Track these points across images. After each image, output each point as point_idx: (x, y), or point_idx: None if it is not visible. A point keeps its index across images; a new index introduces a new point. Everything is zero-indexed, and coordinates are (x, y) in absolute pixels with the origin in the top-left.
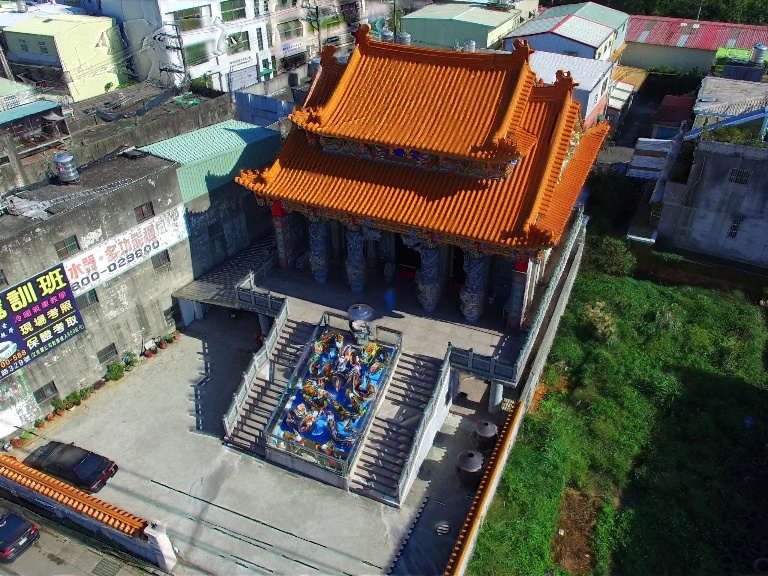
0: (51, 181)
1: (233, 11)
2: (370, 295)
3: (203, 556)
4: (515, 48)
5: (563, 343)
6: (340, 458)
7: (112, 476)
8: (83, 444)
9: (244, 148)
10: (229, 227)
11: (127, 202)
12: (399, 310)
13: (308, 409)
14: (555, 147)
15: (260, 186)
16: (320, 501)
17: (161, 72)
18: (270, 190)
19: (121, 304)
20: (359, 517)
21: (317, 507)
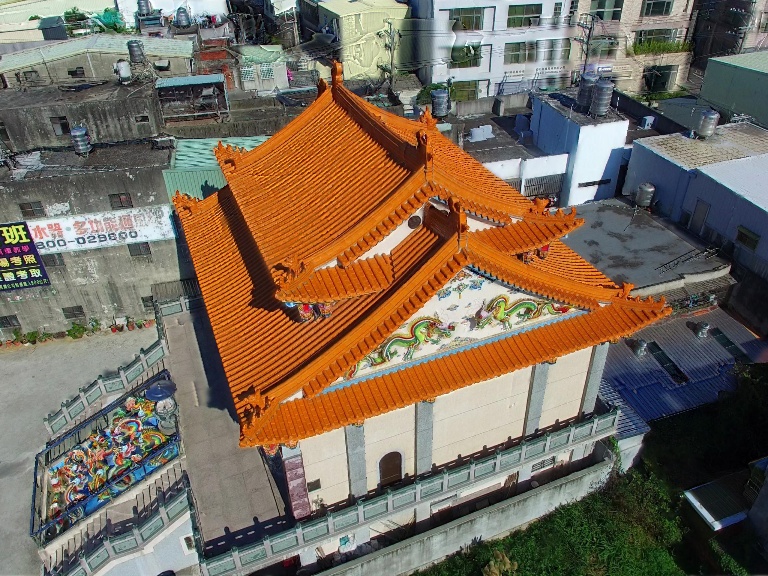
0: None
1: (524, 17)
2: None
3: None
4: None
5: None
6: (63, 526)
7: None
8: None
9: None
10: None
11: (100, 187)
12: None
13: None
14: (389, 307)
15: (186, 214)
16: (19, 554)
17: (378, 68)
18: (188, 222)
19: (91, 275)
20: None
21: (10, 557)
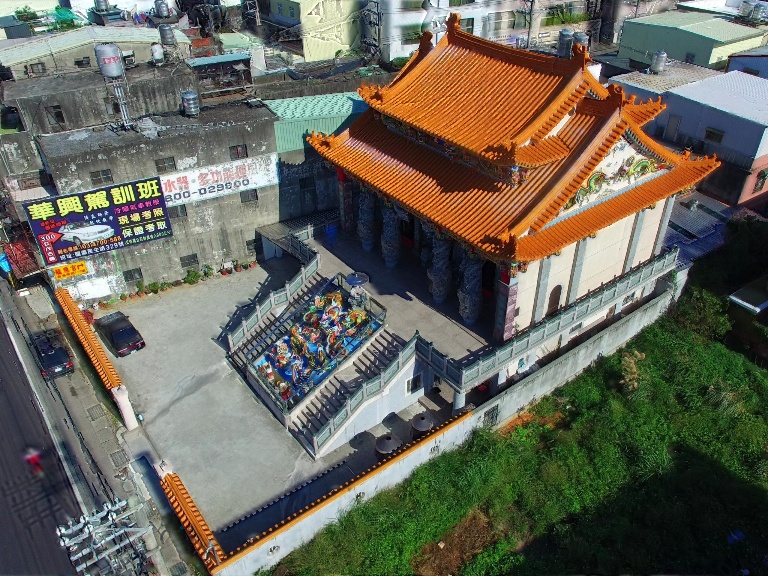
0: (181, 112)
1: None
2: (398, 273)
3: (156, 430)
4: (574, 54)
5: (582, 382)
6: (293, 400)
7: (138, 349)
8: (140, 321)
9: (348, 116)
10: (322, 184)
11: (223, 140)
12: (412, 293)
13: (290, 350)
14: (579, 164)
15: (324, 149)
16: (261, 427)
17: (362, 44)
18: (330, 154)
19: (207, 224)
20: (280, 452)
21: (256, 431)
